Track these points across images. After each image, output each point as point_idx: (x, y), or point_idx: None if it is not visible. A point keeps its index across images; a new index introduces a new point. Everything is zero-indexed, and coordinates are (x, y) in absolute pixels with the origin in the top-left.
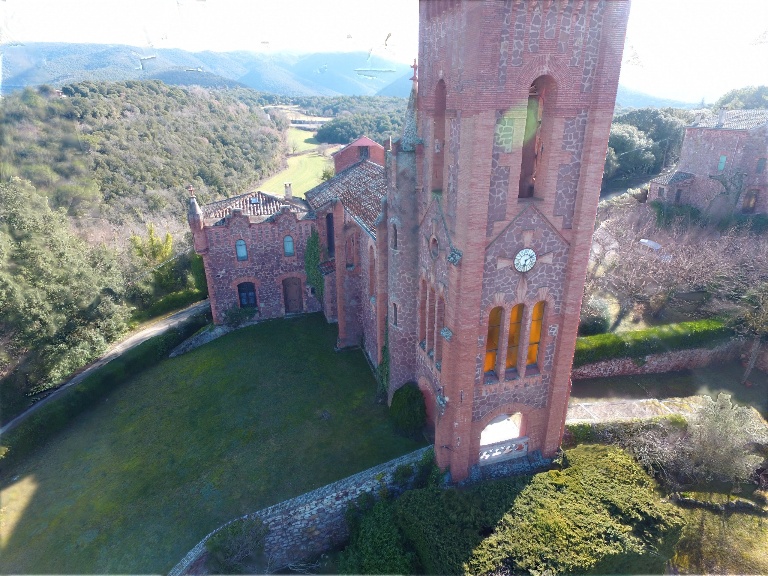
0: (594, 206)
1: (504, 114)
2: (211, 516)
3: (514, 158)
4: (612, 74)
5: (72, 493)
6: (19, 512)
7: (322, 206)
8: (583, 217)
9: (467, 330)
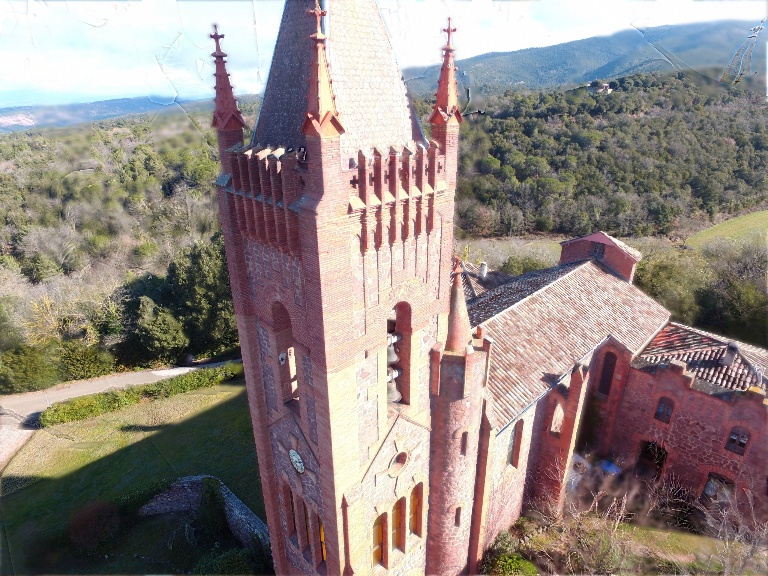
0: (330, 460)
1: (260, 322)
2: (234, 470)
3: (274, 363)
4: (318, 330)
5: (244, 406)
6: (229, 399)
7: (481, 298)
8: (322, 462)
9: (263, 479)
